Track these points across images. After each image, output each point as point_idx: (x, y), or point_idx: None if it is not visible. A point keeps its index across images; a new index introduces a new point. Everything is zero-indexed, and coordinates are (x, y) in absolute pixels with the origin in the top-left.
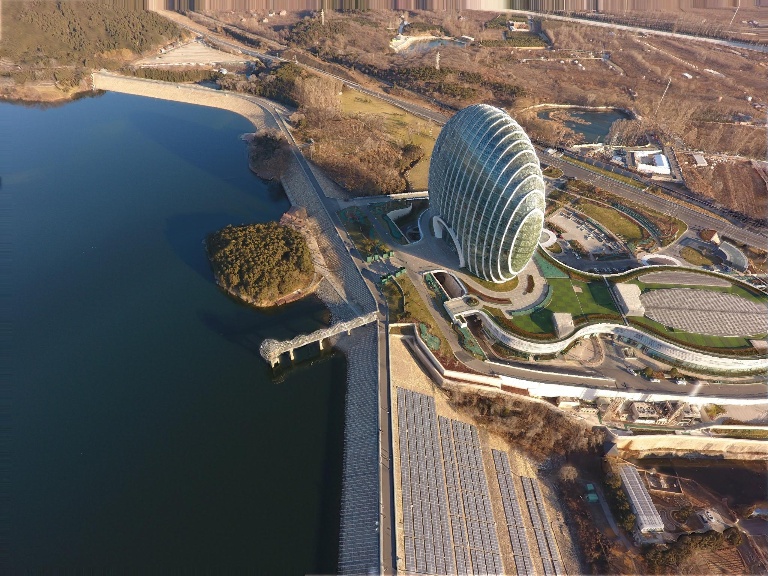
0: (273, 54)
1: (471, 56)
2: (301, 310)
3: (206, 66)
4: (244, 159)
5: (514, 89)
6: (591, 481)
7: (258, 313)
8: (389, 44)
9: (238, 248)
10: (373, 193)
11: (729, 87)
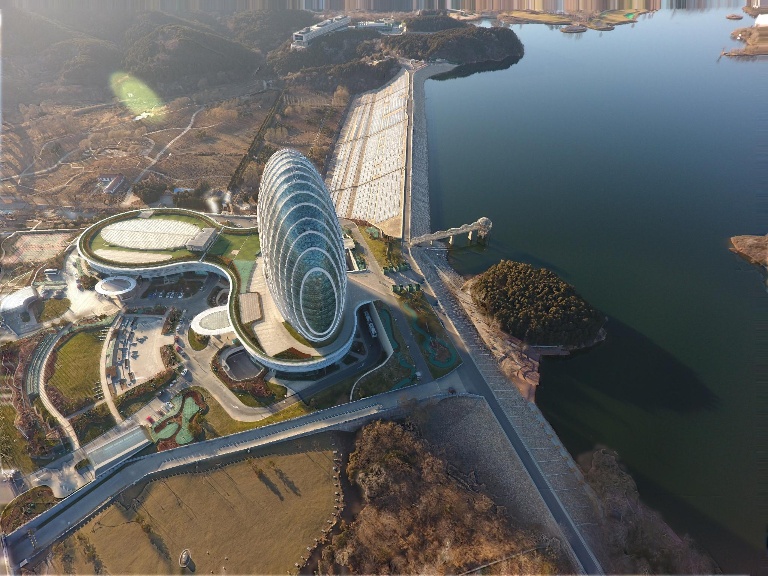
0: None
1: None
2: (474, 268)
3: None
4: None
5: None
6: None
7: None
8: None
9: None
10: None
11: None
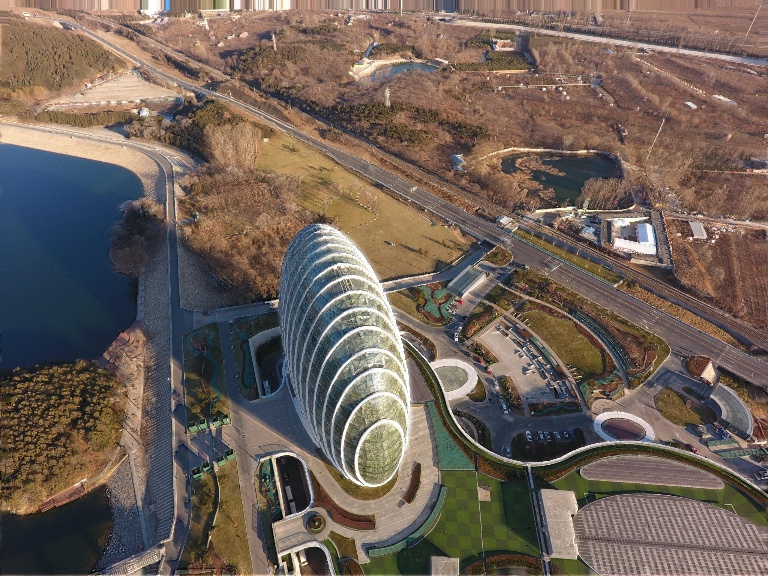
0: (212, 87)
1: (438, 84)
2: (73, 521)
3: (129, 104)
4: (103, 244)
5: (476, 130)
6: None
7: (8, 527)
8: (349, 71)
9: (3, 416)
10: (244, 301)
11: (741, 120)
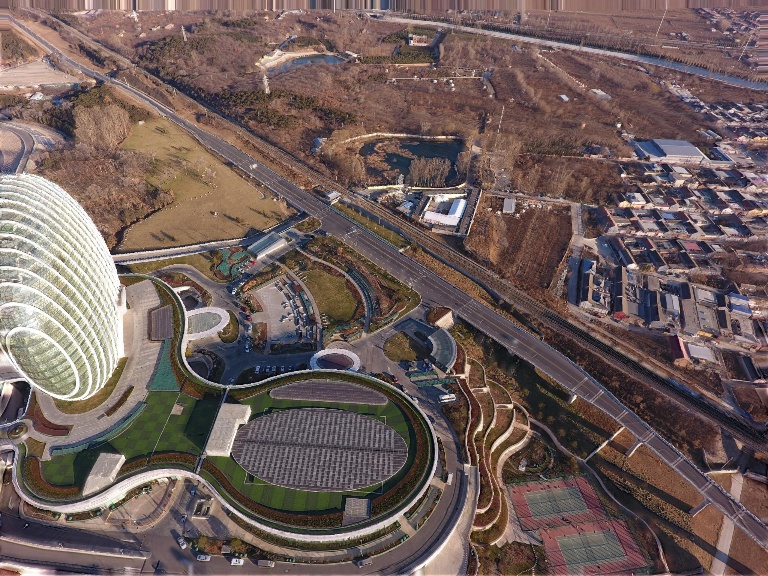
0: None
1: (334, 75)
2: None
3: (26, 89)
4: None
5: (344, 116)
6: None
7: None
8: (256, 62)
9: None
10: None
11: (604, 111)
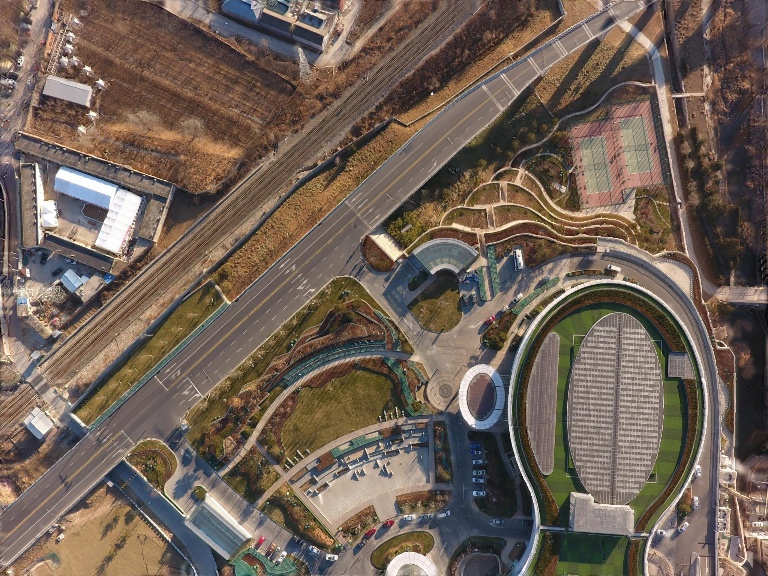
0: None
1: None
2: None
3: None
4: None
5: None
6: (758, 575)
7: None
8: None
9: None
10: None
11: None
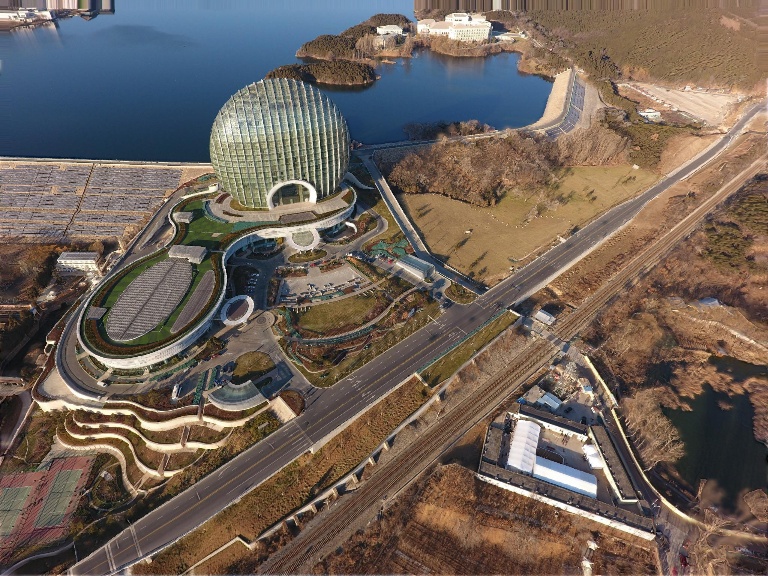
0: None
1: None
2: None
3: (666, 108)
4: None
5: None
6: None
7: None
8: None
9: None
10: None
11: None
